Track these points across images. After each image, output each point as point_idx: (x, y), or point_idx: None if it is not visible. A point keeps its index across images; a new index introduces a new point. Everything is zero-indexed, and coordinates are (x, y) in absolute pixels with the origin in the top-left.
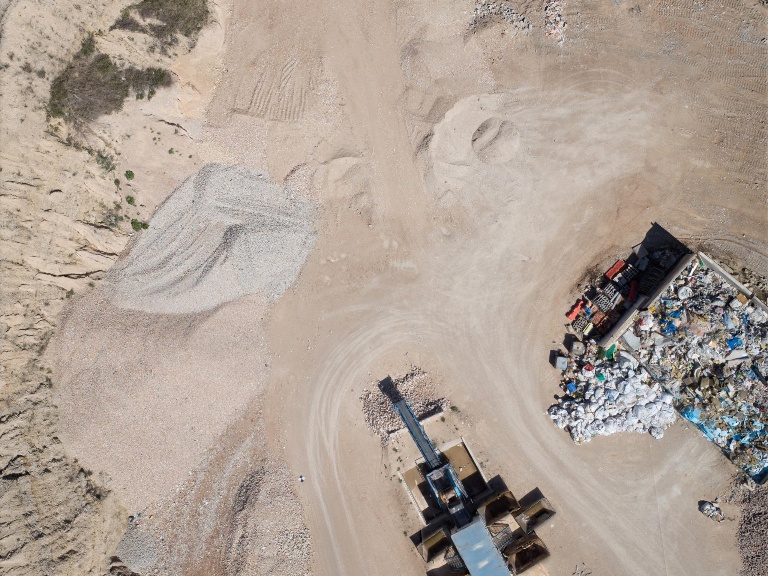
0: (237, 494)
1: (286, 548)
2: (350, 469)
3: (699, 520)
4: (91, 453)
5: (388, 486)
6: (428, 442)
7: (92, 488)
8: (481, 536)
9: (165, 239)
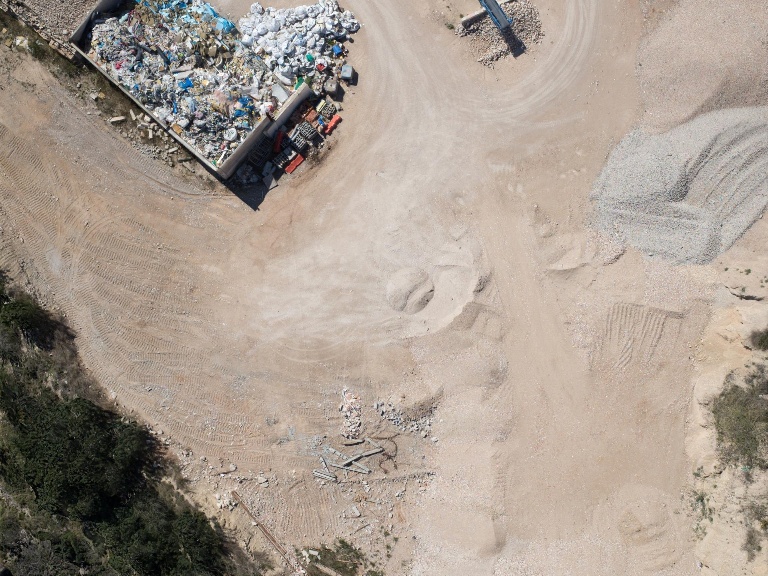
0: None
1: None
2: None
3: None
4: None
5: None
6: None
7: None
8: None
9: (751, 184)
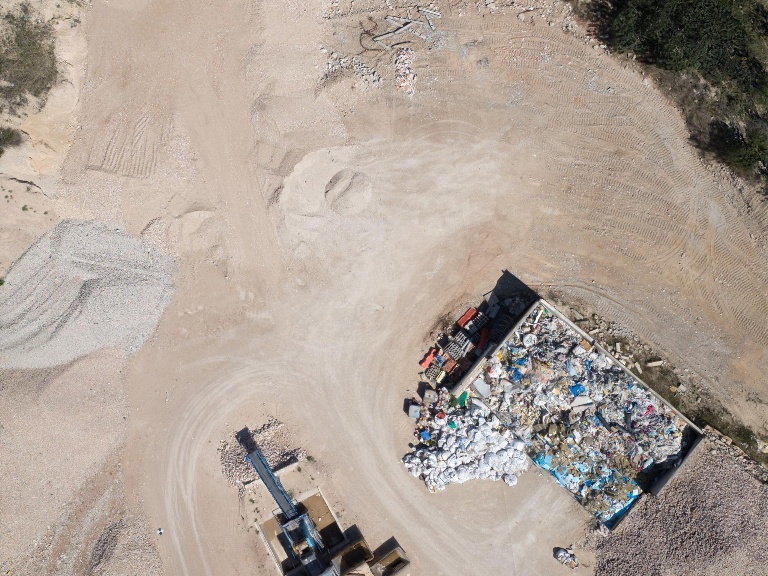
0: (95, 548)
1: None
2: (208, 521)
3: (554, 567)
4: None
5: (246, 537)
6: (283, 493)
7: None
8: None
9: (21, 295)
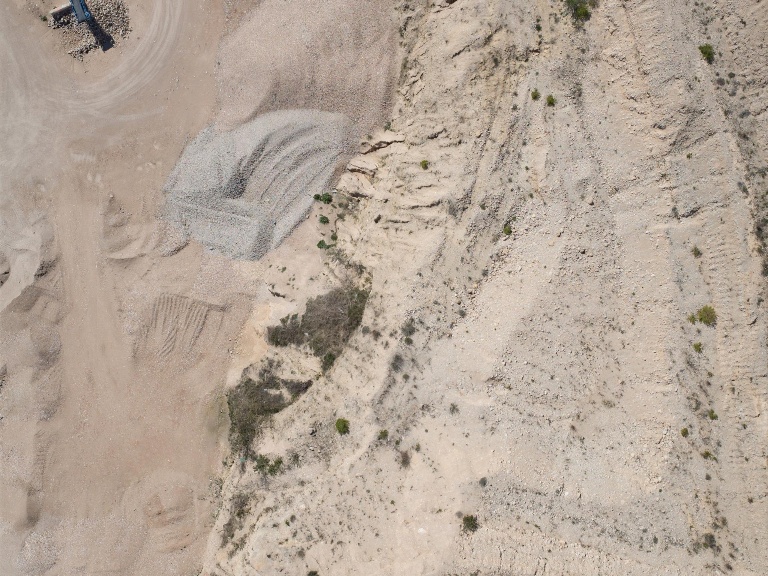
0: None
1: None
2: None
3: None
4: None
5: None
6: None
7: None
8: None
9: (300, 184)
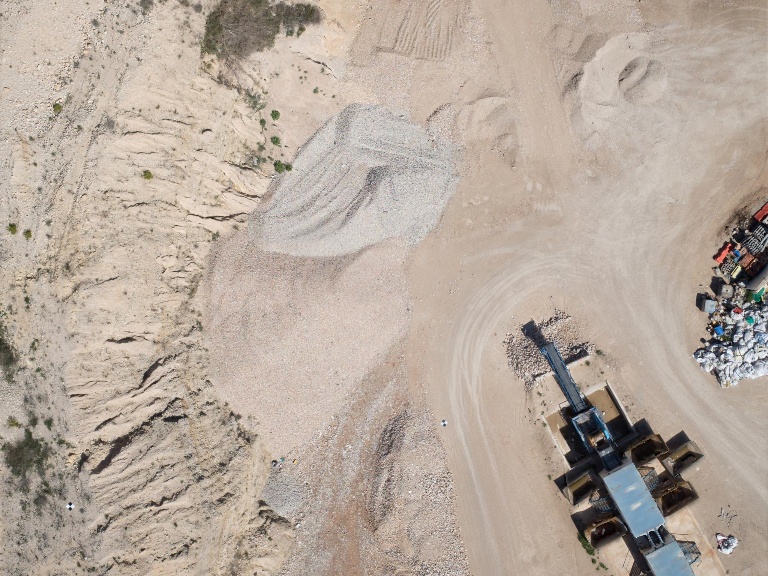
0: (380, 438)
1: (431, 492)
2: (493, 413)
3: None
4: (241, 397)
5: (532, 430)
6: (575, 386)
7: (241, 432)
8: (634, 478)
9: (308, 181)
